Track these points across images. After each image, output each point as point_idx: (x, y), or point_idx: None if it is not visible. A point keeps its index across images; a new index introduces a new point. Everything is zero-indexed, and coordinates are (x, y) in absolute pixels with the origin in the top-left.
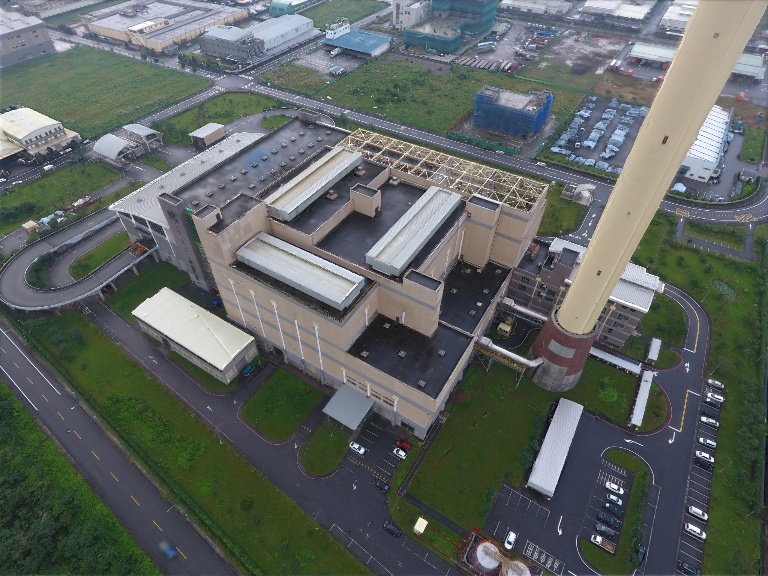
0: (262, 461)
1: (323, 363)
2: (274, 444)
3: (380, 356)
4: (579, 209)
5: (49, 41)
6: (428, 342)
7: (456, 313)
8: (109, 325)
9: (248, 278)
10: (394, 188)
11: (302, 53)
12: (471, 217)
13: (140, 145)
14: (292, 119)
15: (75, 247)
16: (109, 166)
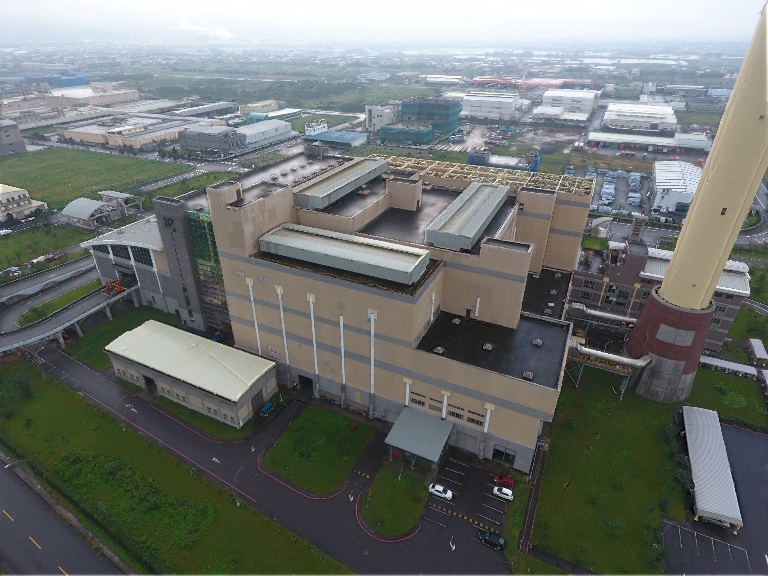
0: (304, 524)
1: (375, 381)
2: (318, 498)
3: (460, 352)
4: (601, 240)
5: (21, 141)
6: (515, 334)
7: None
8: (69, 374)
9: (276, 267)
10: (428, 192)
11: (283, 147)
12: (524, 209)
13: (117, 209)
14: (297, 154)
15: (30, 299)
16: (79, 228)
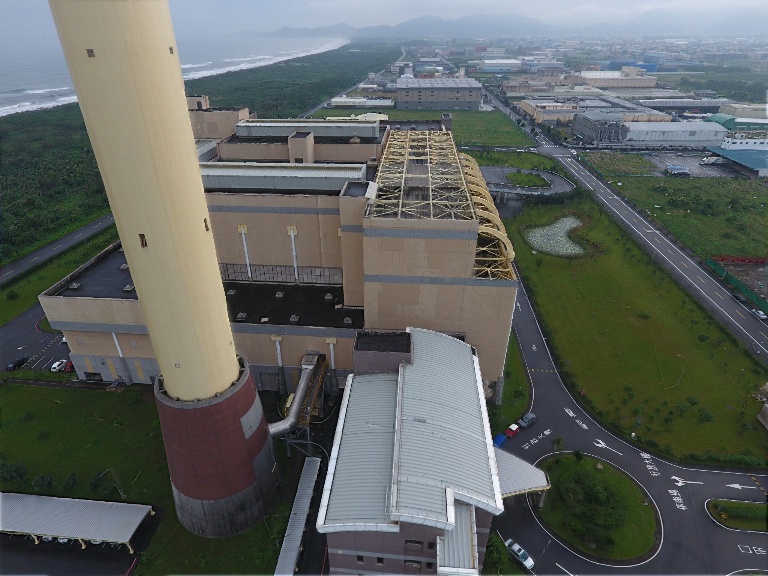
0: None
1: None
2: None
3: (122, 258)
4: (761, 454)
5: (478, 102)
6: None
7: (237, 305)
8: None
9: None
10: None
11: (672, 154)
12: None
13: None
14: (433, 121)
15: None
16: None
